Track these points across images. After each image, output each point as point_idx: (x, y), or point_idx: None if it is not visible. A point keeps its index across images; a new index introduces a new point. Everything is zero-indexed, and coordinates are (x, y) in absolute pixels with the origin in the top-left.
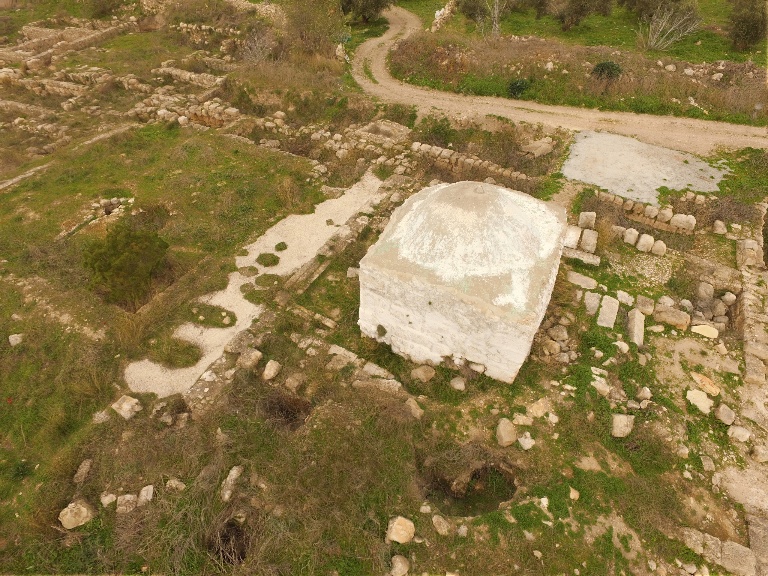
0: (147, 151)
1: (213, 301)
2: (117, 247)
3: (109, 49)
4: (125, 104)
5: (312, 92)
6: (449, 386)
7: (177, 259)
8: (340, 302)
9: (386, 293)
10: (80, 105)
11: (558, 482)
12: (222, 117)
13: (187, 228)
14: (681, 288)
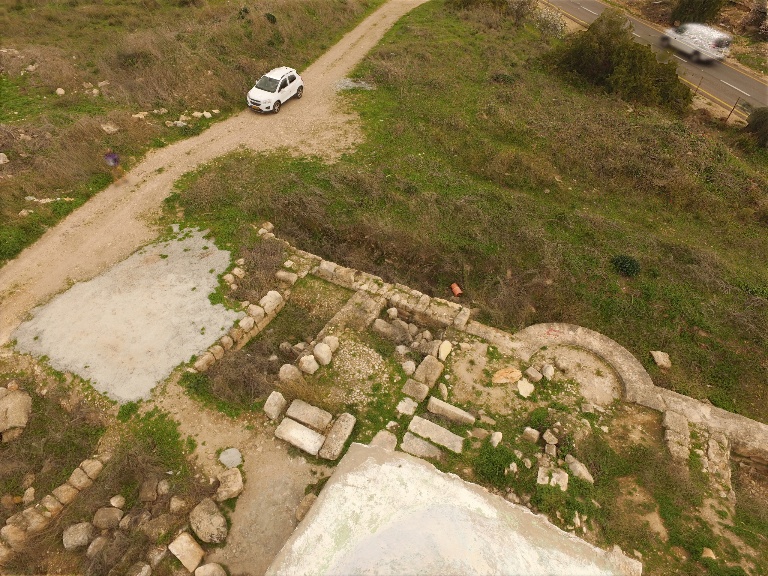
0: None
1: None
2: None
3: None
4: None
5: None
6: None
7: None
8: None
9: None
10: None
11: (699, 568)
12: None
13: None
14: (379, 346)
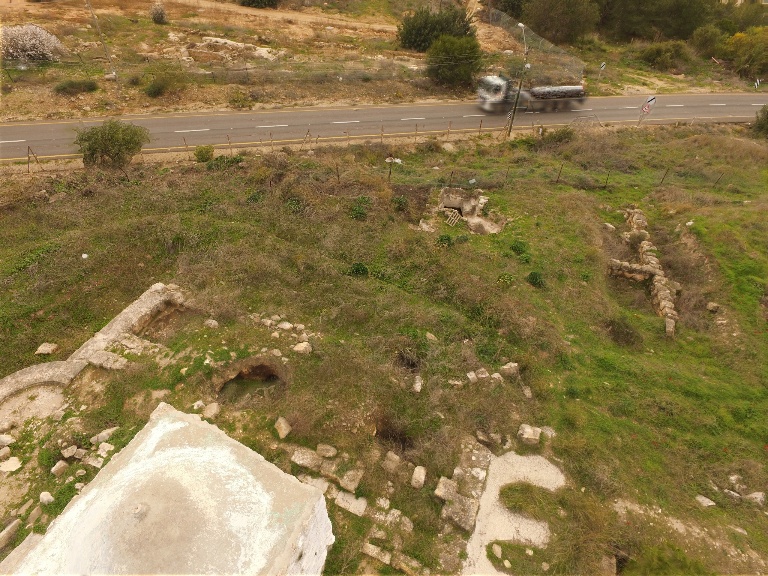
0: None
1: None
2: None
3: None
4: None
5: None
6: None
7: None
8: None
9: None
10: None
11: None
12: None
13: None
14: None
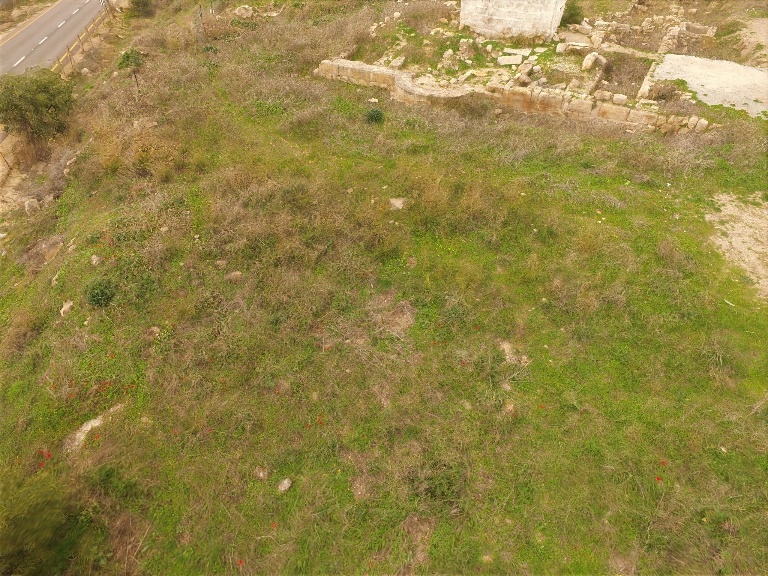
0: None
1: None
2: None
3: None
4: None
5: None
6: None
7: None
8: None
9: None
10: None
11: None
12: None
13: None
14: (557, 80)
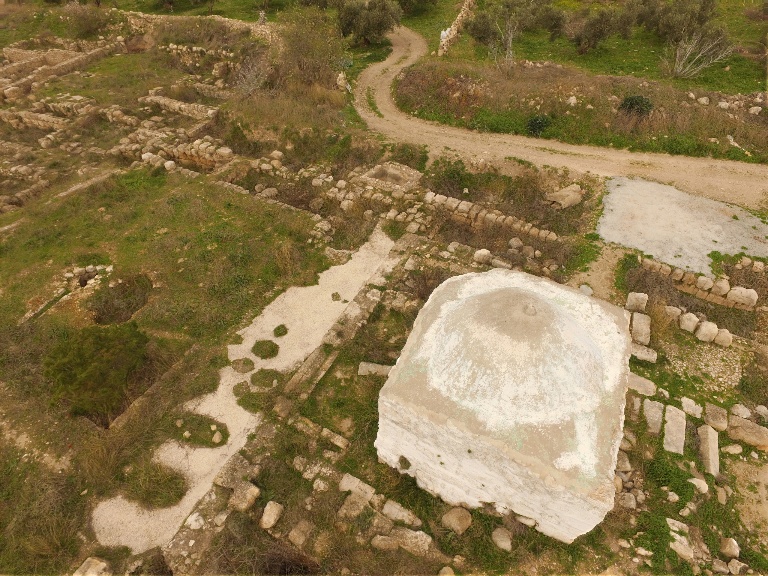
0: (129, 204)
1: (201, 408)
2: (84, 355)
3: (94, 73)
4: (109, 139)
5: (312, 129)
6: (491, 544)
7: (159, 350)
8: (351, 410)
9: (412, 429)
10: (59, 141)
11: None
12: (213, 158)
13: (172, 306)
14: (753, 389)
